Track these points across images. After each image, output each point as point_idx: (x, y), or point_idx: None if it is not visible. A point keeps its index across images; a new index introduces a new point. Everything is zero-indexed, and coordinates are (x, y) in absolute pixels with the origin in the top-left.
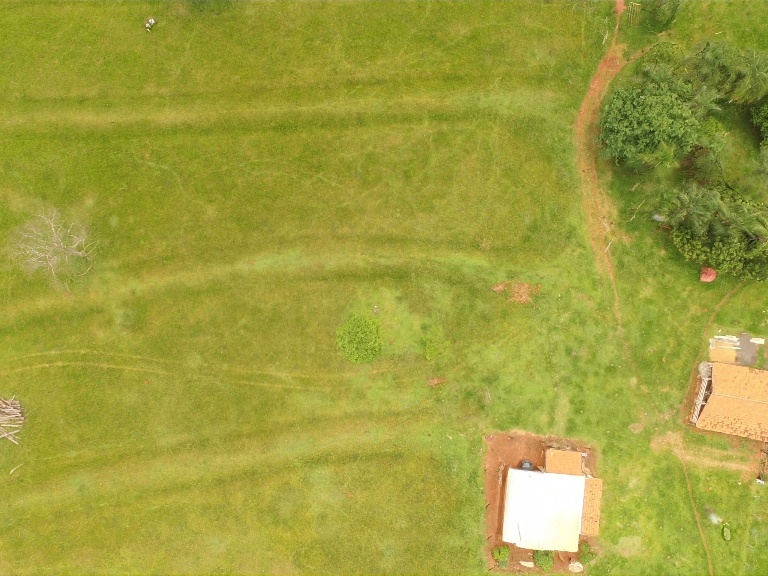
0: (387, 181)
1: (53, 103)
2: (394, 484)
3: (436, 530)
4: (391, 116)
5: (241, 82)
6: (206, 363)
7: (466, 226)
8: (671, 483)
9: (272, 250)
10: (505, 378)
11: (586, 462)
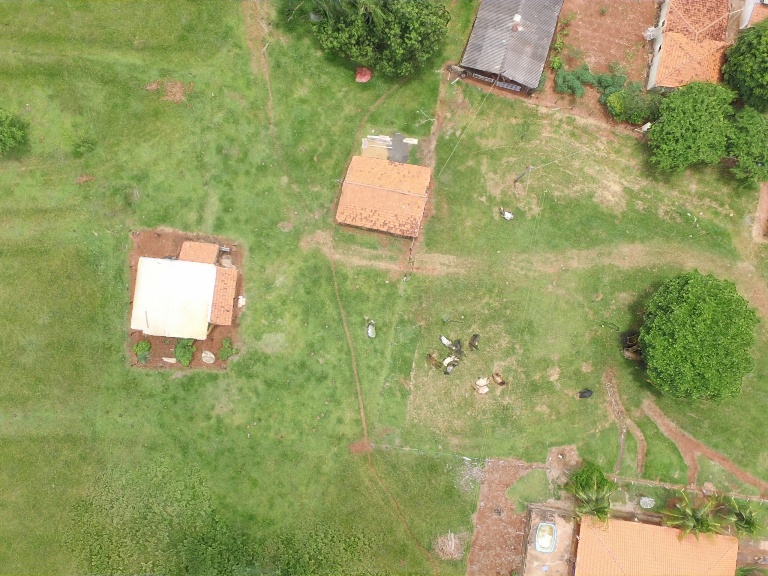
0: None
1: None
2: (38, 280)
3: (78, 325)
4: None
5: None
6: None
7: (120, 25)
8: (318, 281)
9: None
10: (155, 176)
11: (233, 259)
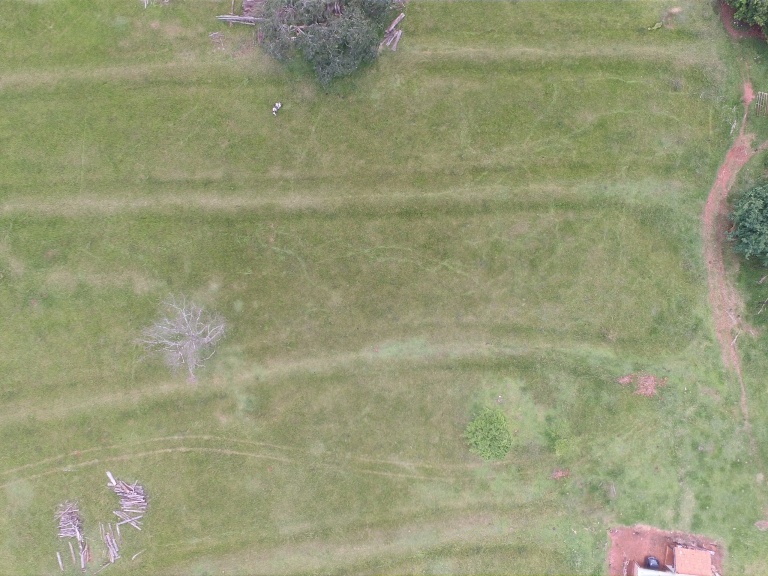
0: (512, 270)
1: (177, 185)
2: None
3: None
4: (517, 204)
5: (366, 167)
6: (329, 451)
7: (592, 317)
8: None
9: (396, 338)
10: (630, 472)
11: (712, 559)
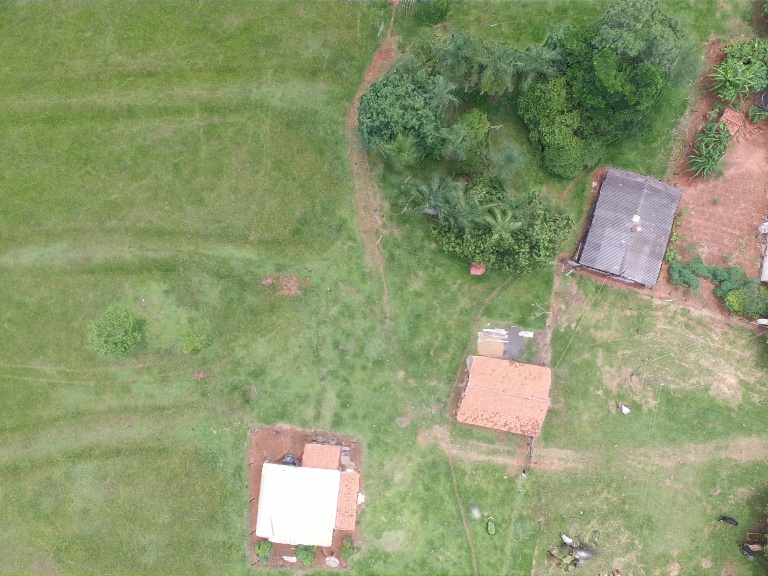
0: (156, 174)
1: None
2: (157, 479)
3: (199, 525)
4: (162, 108)
5: (11, 74)
6: None
7: (235, 219)
8: (436, 477)
9: (39, 243)
10: (272, 372)
11: (351, 456)
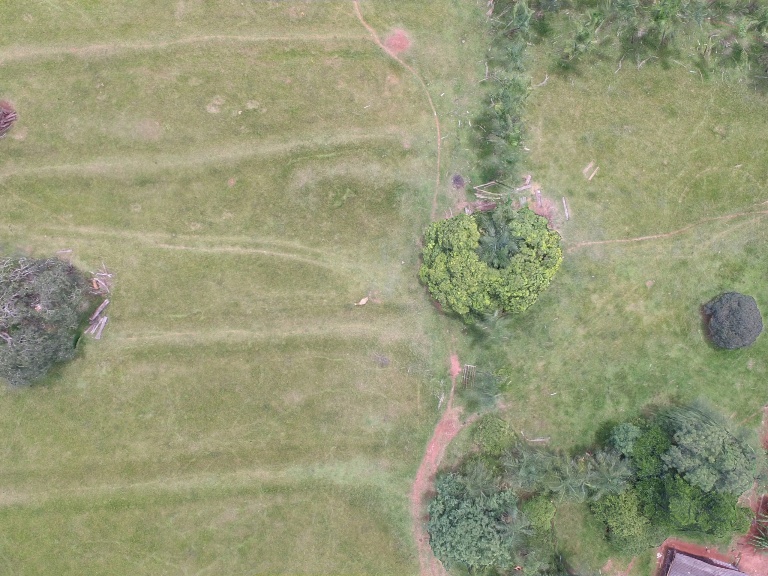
0: (221, 559)
1: None
2: None
3: None
4: (225, 490)
5: (73, 459)
6: None
7: None
8: None
9: None
10: None
11: None
